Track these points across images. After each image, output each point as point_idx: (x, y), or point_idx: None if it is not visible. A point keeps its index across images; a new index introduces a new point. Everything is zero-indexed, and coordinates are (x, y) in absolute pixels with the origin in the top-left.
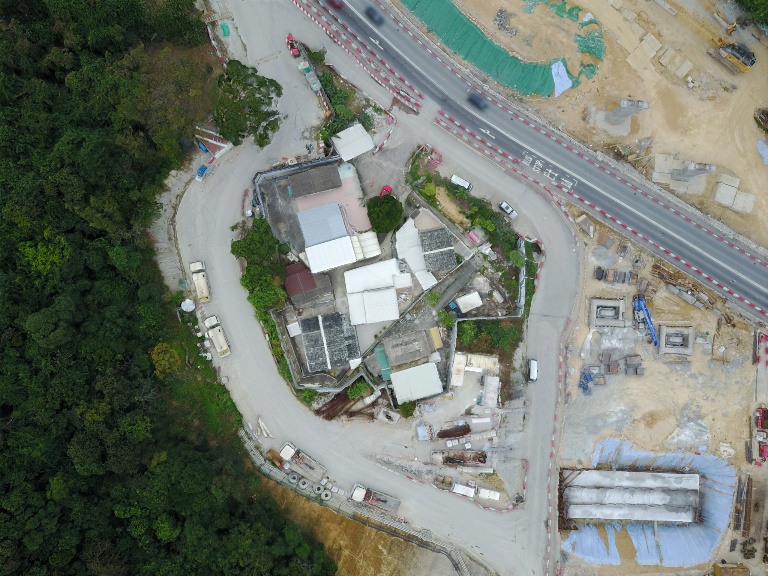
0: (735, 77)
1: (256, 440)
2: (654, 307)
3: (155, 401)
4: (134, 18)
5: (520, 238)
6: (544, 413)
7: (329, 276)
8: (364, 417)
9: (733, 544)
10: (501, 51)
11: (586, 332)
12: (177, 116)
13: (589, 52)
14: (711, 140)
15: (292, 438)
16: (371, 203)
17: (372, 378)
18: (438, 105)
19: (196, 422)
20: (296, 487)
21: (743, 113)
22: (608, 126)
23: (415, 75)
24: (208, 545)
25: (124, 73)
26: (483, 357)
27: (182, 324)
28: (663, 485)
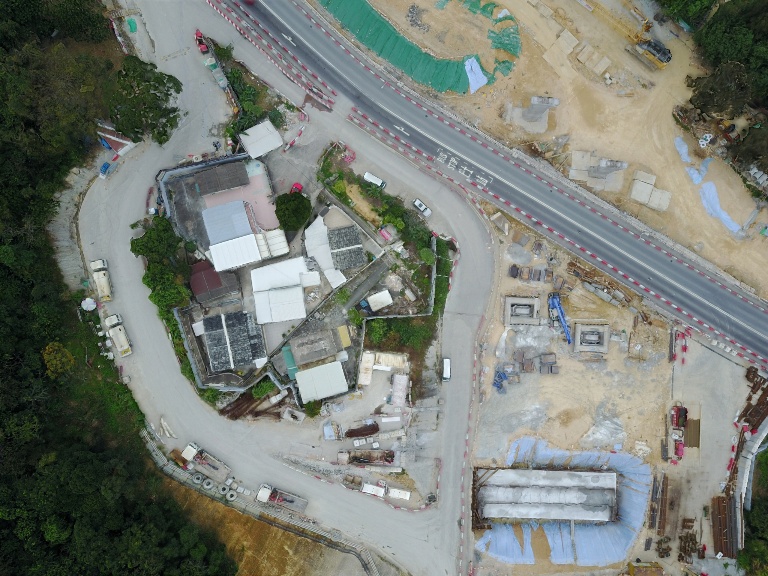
0: (653, 74)
1: (159, 440)
2: (570, 305)
3: (49, 401)
4: (31, 13)
5: (434, 236)
6: (458, 412)
7: (237, 274)
8: (270, 417)
9: (648, 543)
10: (414, 47)
11: (501, 330)
12: (67, 112)
13: (504, 48)
14: (628, 137)
15: (196, 438)
16: (278, 201)
17: (280, 377)
18: (352, 102)
19: (95, 422)
20: (200, 488)
21: (661, 110)
22: (525, 123)
23: (328, 72)
24: (97, 547)
25: (12, 69)
26: (391, 356)
27: (82, 323)
28: (580, 484)
